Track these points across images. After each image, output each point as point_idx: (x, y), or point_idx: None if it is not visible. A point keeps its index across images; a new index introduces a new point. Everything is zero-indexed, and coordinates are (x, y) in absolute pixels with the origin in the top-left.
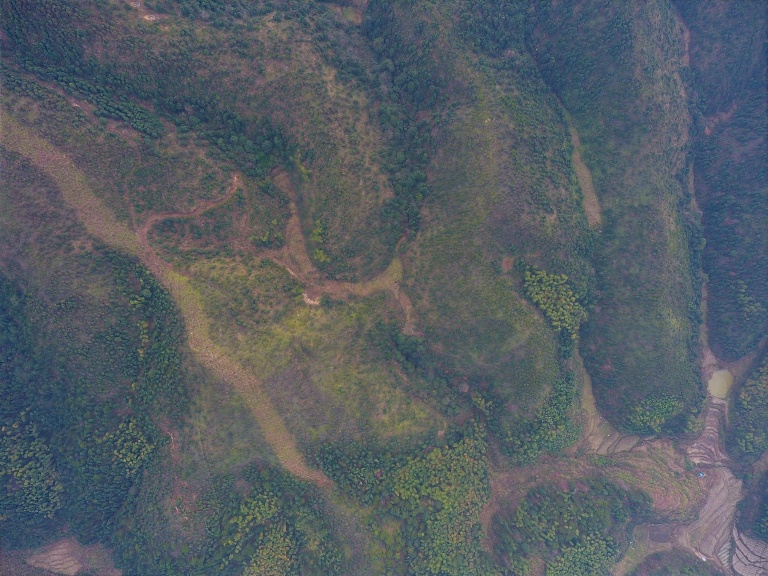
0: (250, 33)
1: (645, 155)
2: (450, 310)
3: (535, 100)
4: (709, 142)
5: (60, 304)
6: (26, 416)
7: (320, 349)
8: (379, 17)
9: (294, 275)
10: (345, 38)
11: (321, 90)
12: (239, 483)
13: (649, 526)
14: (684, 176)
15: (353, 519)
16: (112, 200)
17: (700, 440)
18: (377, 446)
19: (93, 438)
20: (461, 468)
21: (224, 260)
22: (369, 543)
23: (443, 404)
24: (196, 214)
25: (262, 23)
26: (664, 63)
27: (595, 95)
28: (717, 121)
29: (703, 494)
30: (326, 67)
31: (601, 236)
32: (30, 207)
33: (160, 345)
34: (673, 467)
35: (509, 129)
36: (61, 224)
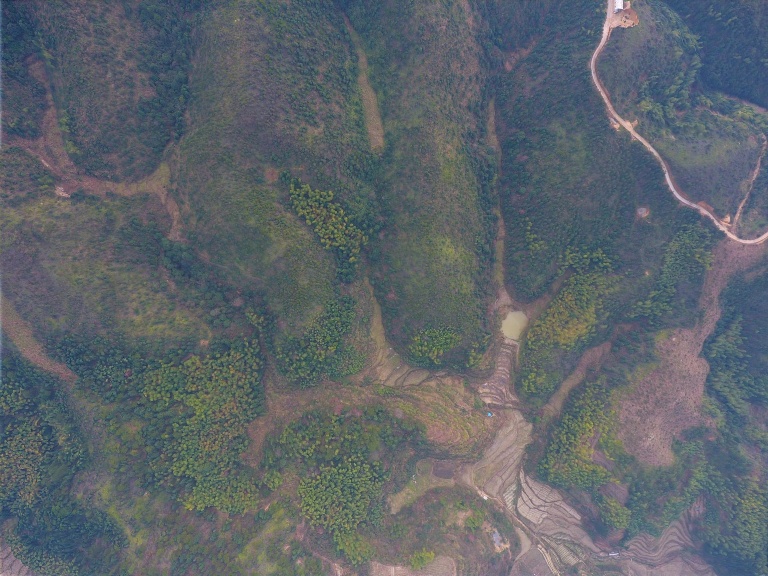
0: None
1: (418, 76)
2: (205, 214)
3: (311, 13)
4: (507, 77)
5: None
6: None
7: (54, 236)
8: None
9: (48, 167)
10: None
11: None
12: None
13: (433, 461)
14: (479, 109)
15: (92, 414)
16: None
17: (491, 380)
18: (126, 345)
19: None
20: (224, 379)
21: None
22: None
23: (211, 315)
24: None
25: None
26: None
27: (375, 13)
28: (518, 57)
29: (488, 433)
30: None
31: (383, 160)
32: None
33: None
34: (461, 404)
35: (263, 32)
36: None
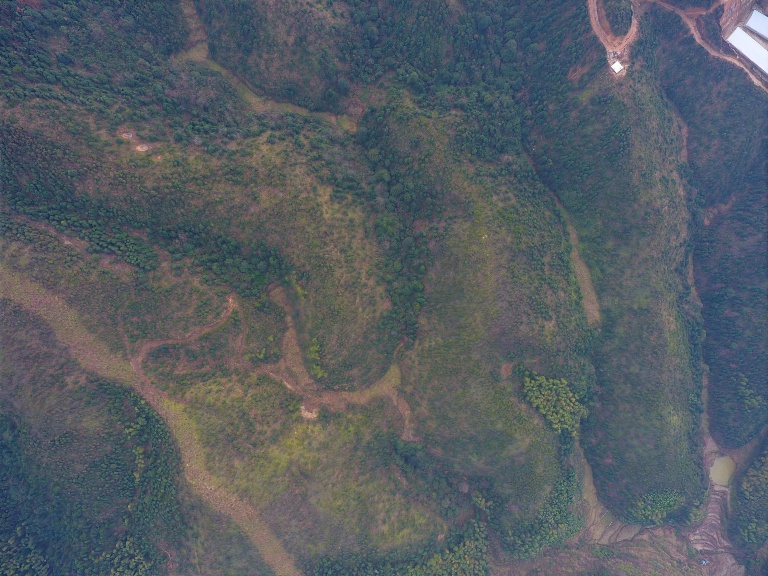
0: (244, 159)
1: (644, 258)
2: (449, 420)
3: (533, 205)
4: (708, 234)
5: (54, 441)
6: (22, 530)
7: (318, 470)
8: (374, 129)
9: (291, 388)
10: (340, 154)
11: (316, 214)
12: None
13: None
14: (683, 268)
15: None
16: (106, 334)
17: (702, 527)
18: (377, 557)
19: (89, 558)
20: (462, 571)
21: (220, 381)
22: None
23: (443, 506)
24: (191, 339)
25: (256, 147)
26: (662, 164)
27: (593, 197)
28: (716, 212)
29: None
30: (321, 187)
31: (600, 333)
32: (22, 350)
33: (156, 472)
34: (675, 555)
35: (507, 243)
36: (54, 362)
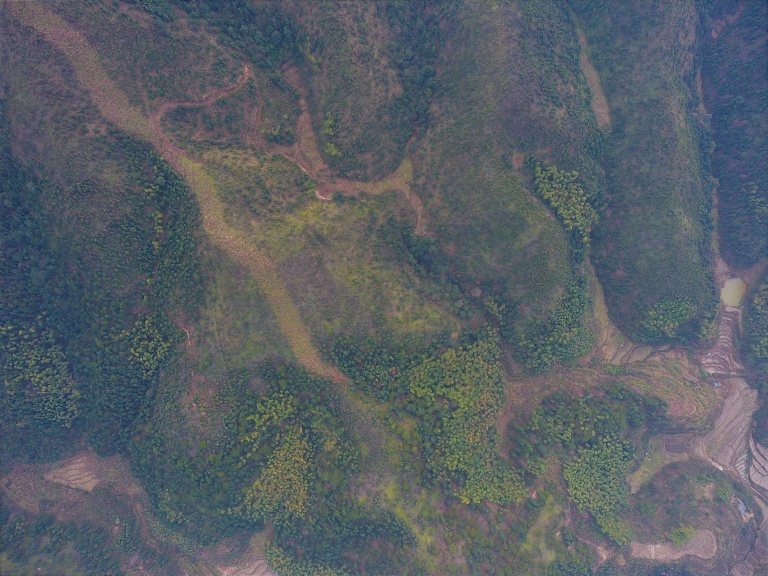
0: None
1: (653, 49)
2: (462, 204)
3: None
4: (716, 45)
5: (76, 187)
6: (42, 321)
7: (333, 238)
8: None
9: (306, 172)
10: None
11: None
12: (255, 381)
13: (665, 437)
14: (692, 79)
15: (369, 414)
16: (125, 83)
17: (714, 350)
18: (392, 343)
19: (110, 335)
20: (475, 370)
21: (236, 151)
22: (386, 437)
23: (456, 307)
24: (208, 103)
25: None
26: None
27: None
28: (724, 24)
29: (718, 403)
30: None
31: (610, 137)
32: (45, 84)
33: (175, 234)
34: (687, 377)
35: (517, 17)
36: (76, 105)
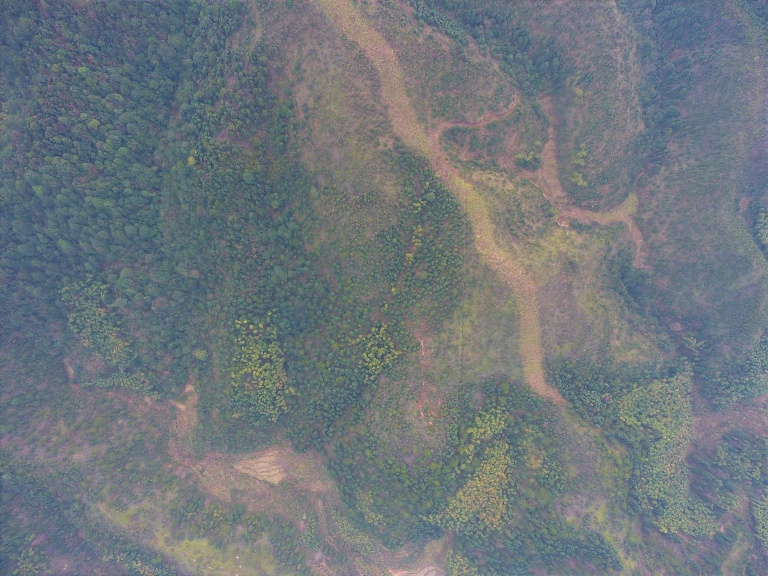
0: None
1: None
2: (691, 243)
3: None
4: None
5: (363, 197)
6: (269, 318)
7: (582, 266)
8: None
9: (546, 197)
10: None
11: (611, 14)
12: (476, 396)
13: None
14: None
15: (585, 438)
16: (417, 101)
17: None
18: (608, 370)
19: (347, 339)
20: (673, 403)
21: (495, 174)
22: (600, 462)
23: (660, 339)
24: (480, 125)
25: None
26: None
27: None
28: None
29: None
30: None
31: None
32: (357, 98)
33: (435, 249)
34: None
35: None
36: (375, 119)
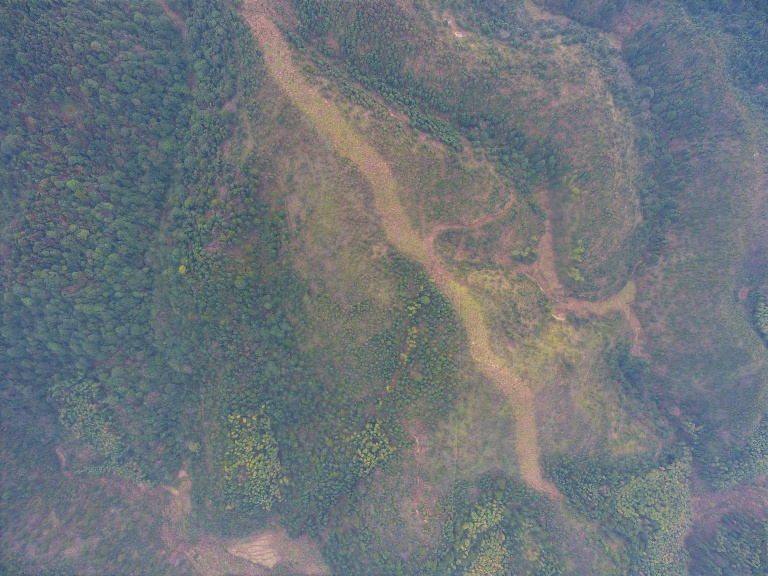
0: (546, 55)
1: None
2: (690, 335)
3: None
4: None
5: (356, 306)
6: (263, 409)
7: (579, 366)
8: (647, 45)
9: (543, 291)
10: (620, 64)
11: (608, 115)
12: (472, 490)
13: None
14: None
15: (583, 534)
16: (411, 209)
17: None
18: (606, 463)
19: (341, 436)
20: (671, 490)
21: (491, 272)
22: (598, 558)
23: (658, 426)
24: (475, 226)
25: (557, 46)
26: None
27: None
28: None
29: None
30: None
31: None
32: (350, 211)
33: (430, 351)
34: None
35: None
36: (368, 229)
